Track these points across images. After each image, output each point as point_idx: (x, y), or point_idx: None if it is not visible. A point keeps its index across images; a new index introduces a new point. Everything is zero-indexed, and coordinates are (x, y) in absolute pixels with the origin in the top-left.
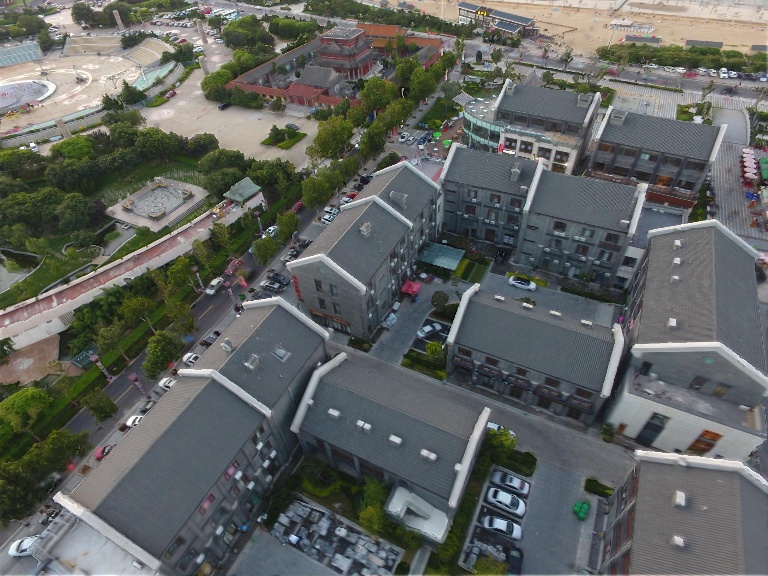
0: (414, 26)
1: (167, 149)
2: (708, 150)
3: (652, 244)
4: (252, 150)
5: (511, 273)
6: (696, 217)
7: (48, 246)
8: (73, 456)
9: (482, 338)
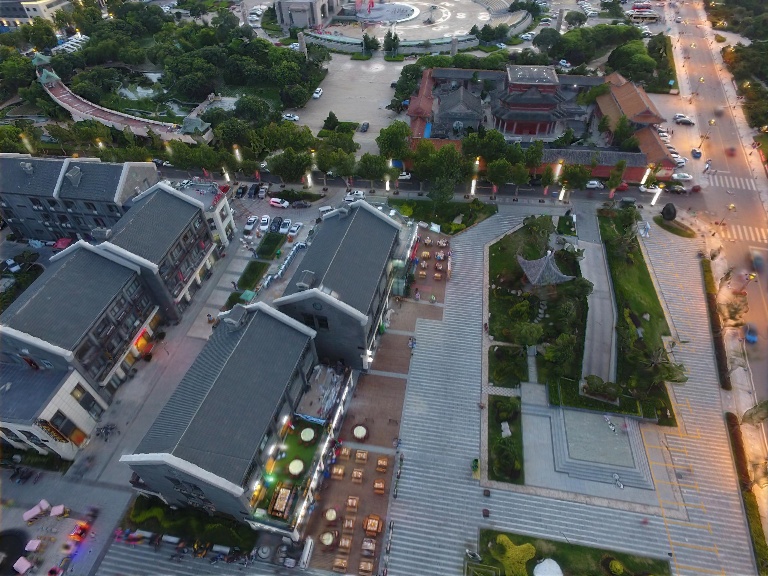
0: None
1: None
2: (146, 450)
3: None
4: (315, 121)
5: None
6: None
7: (175, 94)
8: None
9: None
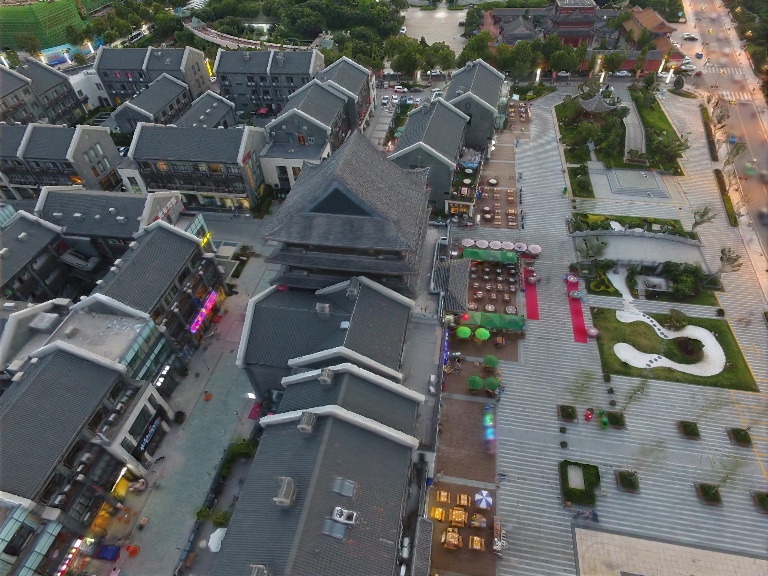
0: (757, 43)
1: (374, 22)
2: None
3: None
4: None
5: None
6: None
7: None
8: None
9: None
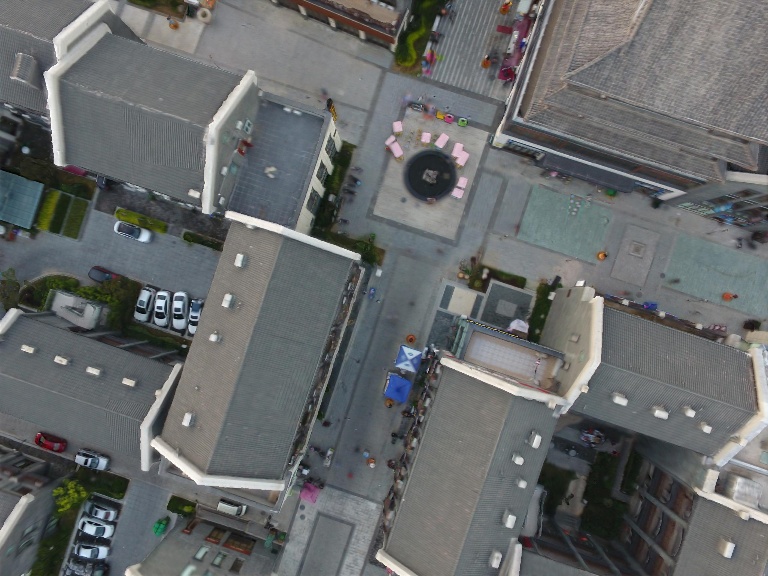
0: None
1: None
2: None
3: (226, 240)
4: None
5: (118, 213)
6: (404, 56)
7: None
8: None
9: (15, 408)
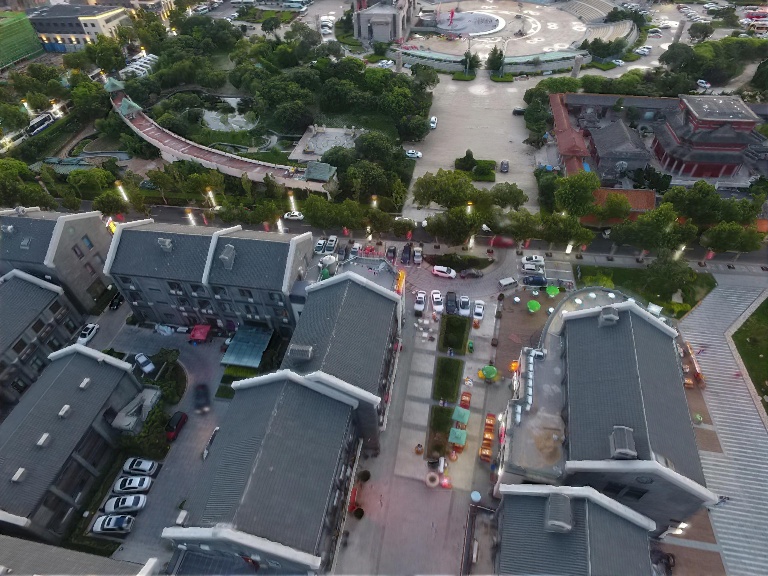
0: None
1: (391, 113)
2: None
3: (126, 563)
4: (442, 159)
5: None
6: None
7: (268, 124)
8: (40, 207)
9: (42, 379)
